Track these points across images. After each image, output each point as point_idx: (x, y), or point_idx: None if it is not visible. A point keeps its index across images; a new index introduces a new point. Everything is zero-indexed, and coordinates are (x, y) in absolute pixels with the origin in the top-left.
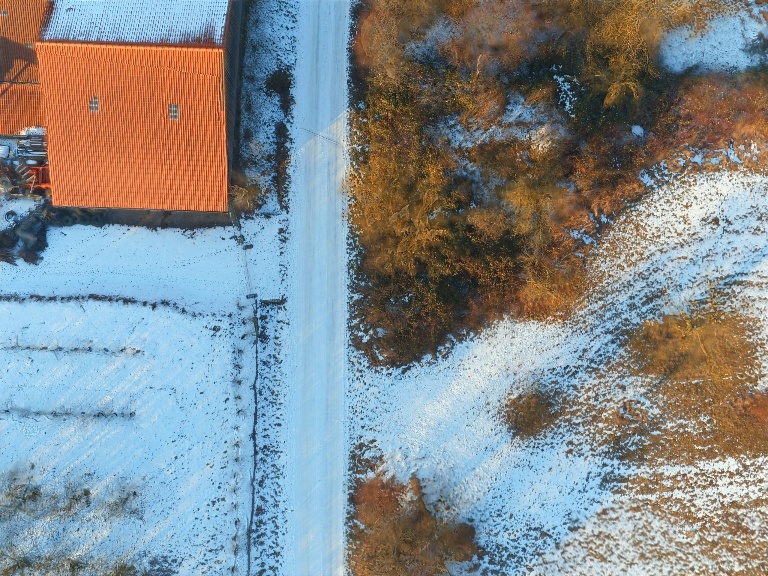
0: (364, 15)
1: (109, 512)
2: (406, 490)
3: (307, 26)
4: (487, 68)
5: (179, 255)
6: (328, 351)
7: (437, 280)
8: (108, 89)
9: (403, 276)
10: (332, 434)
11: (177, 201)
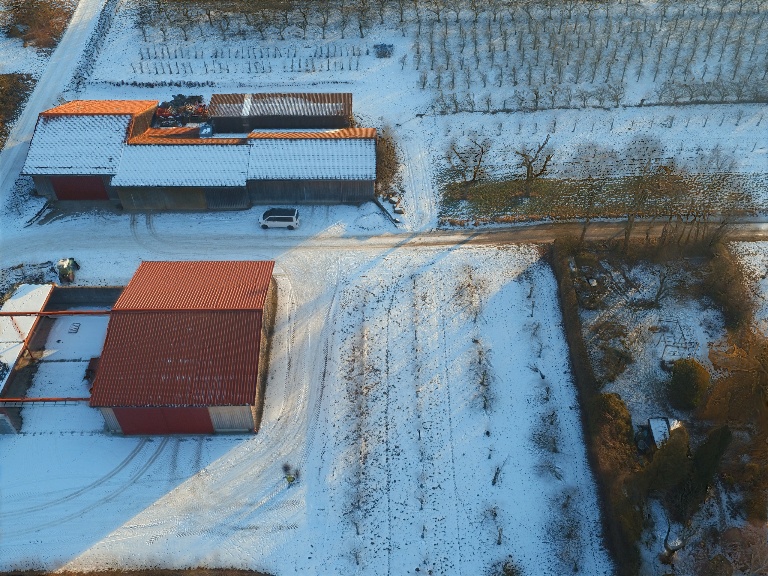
0: None
1: None
2: (30, 45)
3: (10, 182)
4: None
5: None
6: None
7: None
8: None
9: None
10: (58, 60)
11: None
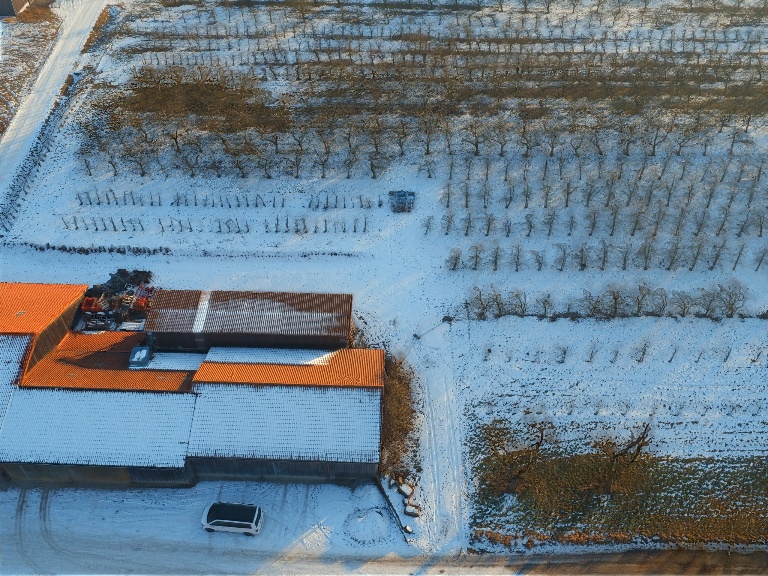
0: None
1: (106, 168)
2: None
3: None
4: None
5: (26, 276)
6: None
7: None
8: (4, 318)
9: None
10: None
11: (2, 285)
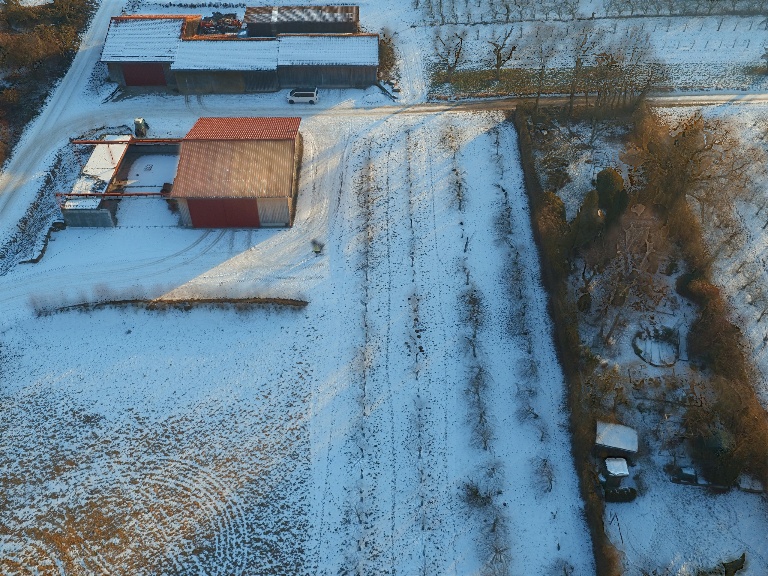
0: (58, 74)
1: None
2: None
3: (87, 73)
4: (8, 60)
5: None
6: (109, 3)
7: (57, 8)
8: None
9: (70, 9)
10: None
11: None
